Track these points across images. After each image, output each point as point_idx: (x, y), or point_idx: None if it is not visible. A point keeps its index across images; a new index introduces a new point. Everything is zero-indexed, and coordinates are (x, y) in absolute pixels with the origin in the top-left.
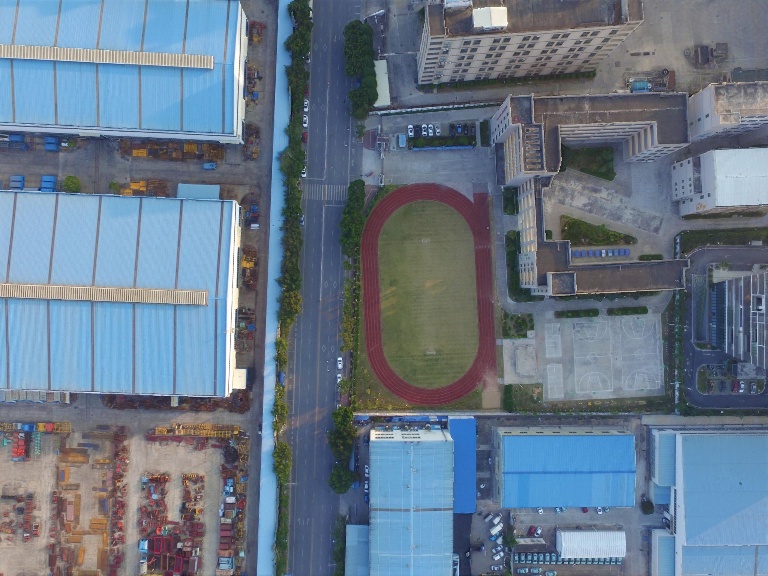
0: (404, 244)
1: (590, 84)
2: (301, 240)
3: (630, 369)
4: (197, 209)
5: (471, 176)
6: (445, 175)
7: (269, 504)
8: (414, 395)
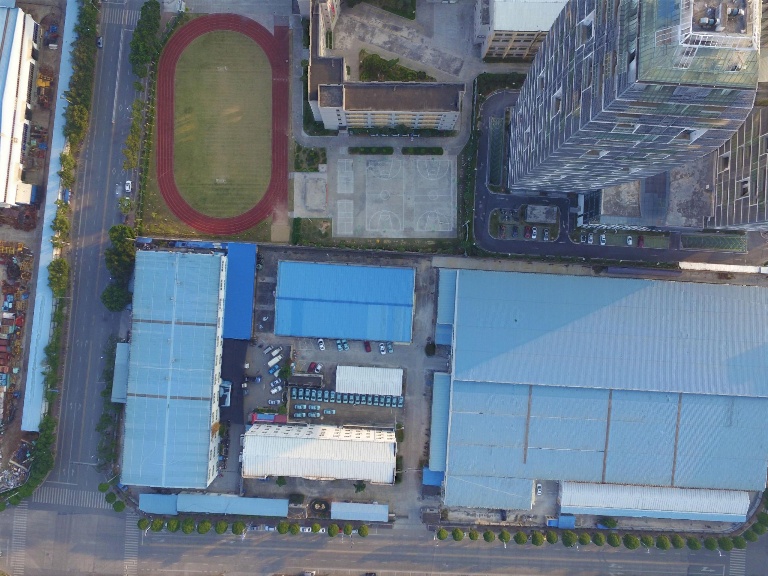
0: (201, 72)
1: None
2: (89, 55)
3: (422, 210)
4: None
5: (273, 9)
6: (246, 6)
7: (43, 319)
8: (202, 223)
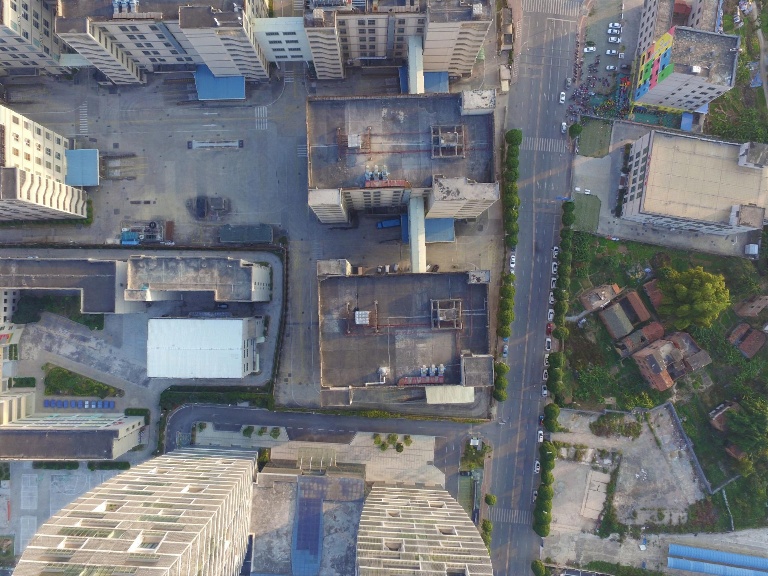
0: None
1: (86, 230)
2: None
3: None
4: None
5: None
6: None
7: None
8: None
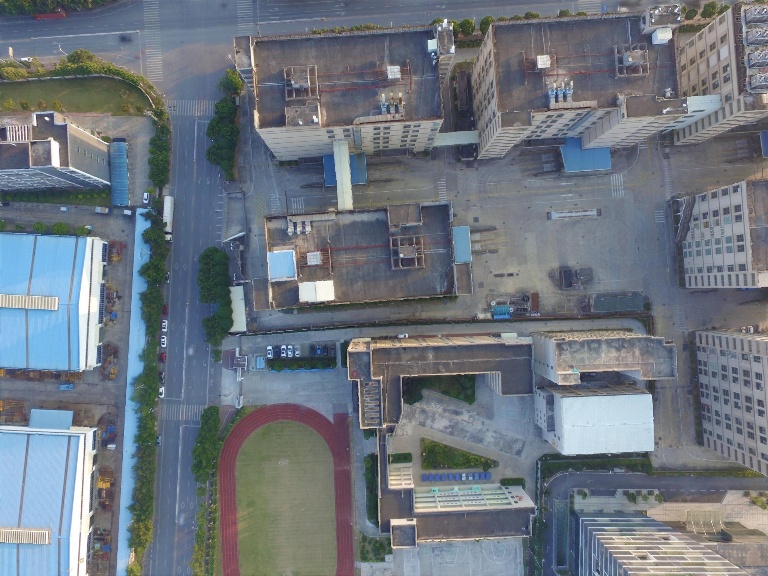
0: (262, 465)
1: (452, 305)
2: (152, 470)
3: None
4: (43, 444)
5: (331, 397)
6: (305, 396)
7: None
8: None
